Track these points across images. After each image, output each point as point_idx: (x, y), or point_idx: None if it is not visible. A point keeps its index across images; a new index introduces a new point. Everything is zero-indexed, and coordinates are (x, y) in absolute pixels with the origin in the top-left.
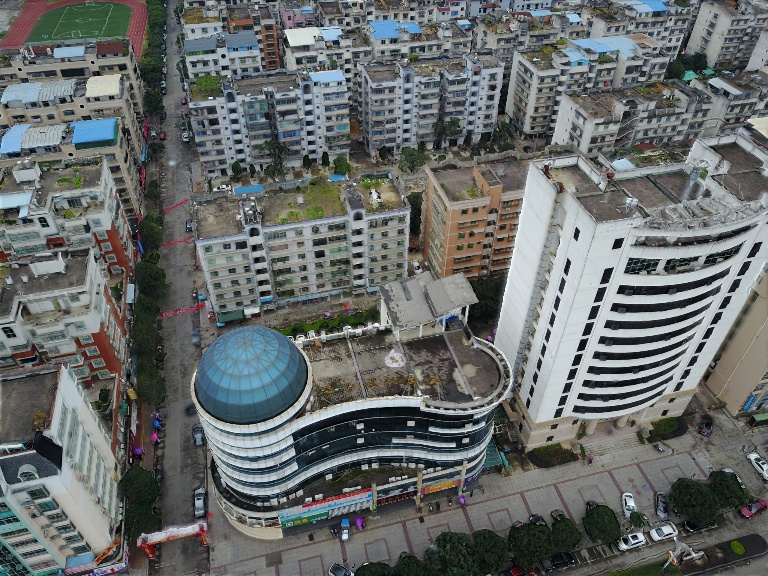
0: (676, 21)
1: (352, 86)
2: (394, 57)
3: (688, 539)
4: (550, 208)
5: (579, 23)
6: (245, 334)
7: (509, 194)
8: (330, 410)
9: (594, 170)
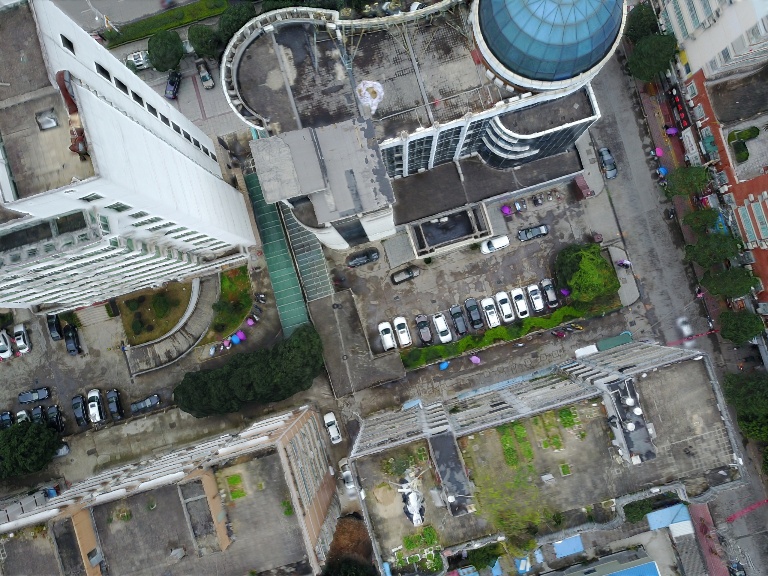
0: None
1: None
2: None
3: None
4: None
5: None
6: None
7: None
8: (446, 0)
9: None
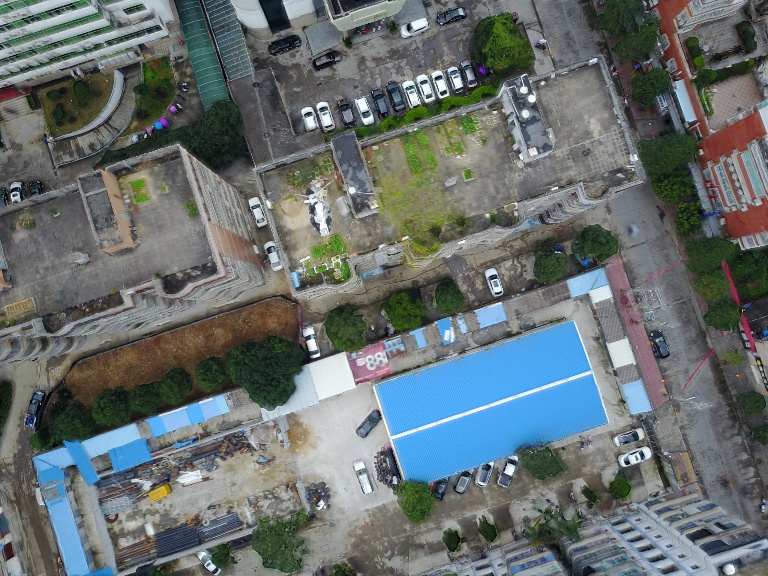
0: None
1: None
2: None
3: None
4: None
5: None
6: None
7: (73, 187)
8: None
9: None
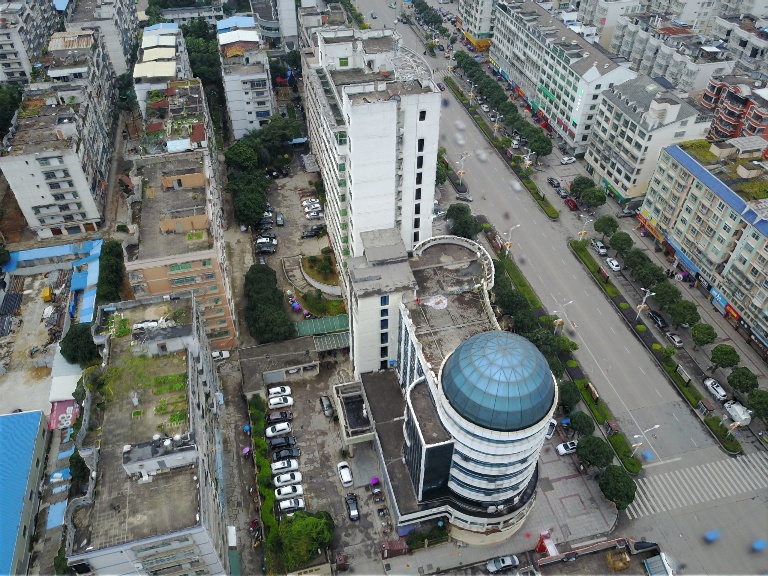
0: None
1: None
2: None
3: (484, 243)
4: (395, 118)
5: None
6: (491, 352)
7: None
8: None
9: (367, 84)
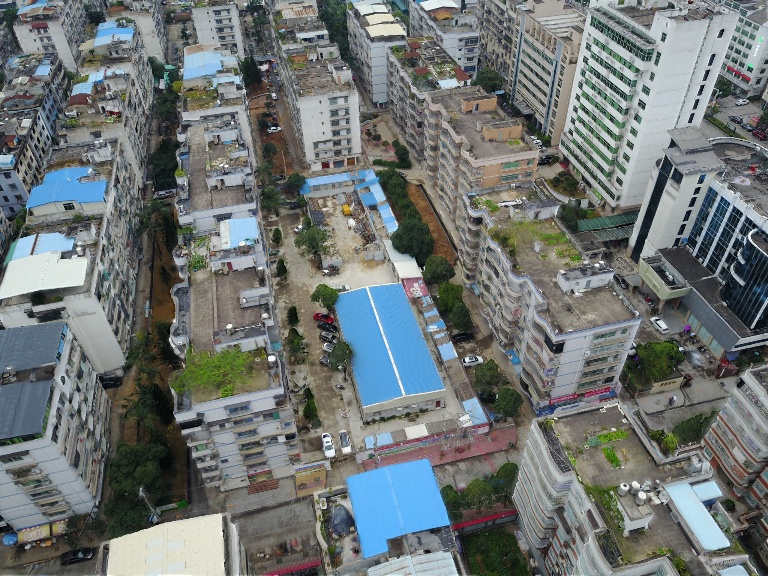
0: None
1: (122, 278)
2: (116, 209)
3: None
4: None
5: (124, 74)
6: None
7: None
8: None
9: None
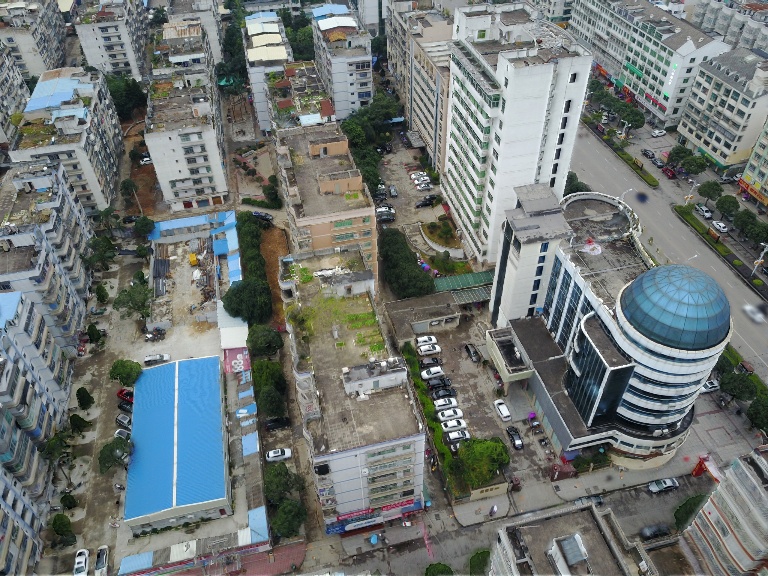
0: (7, 58)
1: None
2: None
3: None
4: None
5: None
6: (676, 280)
7: None
8: None
9: (521, 50)
